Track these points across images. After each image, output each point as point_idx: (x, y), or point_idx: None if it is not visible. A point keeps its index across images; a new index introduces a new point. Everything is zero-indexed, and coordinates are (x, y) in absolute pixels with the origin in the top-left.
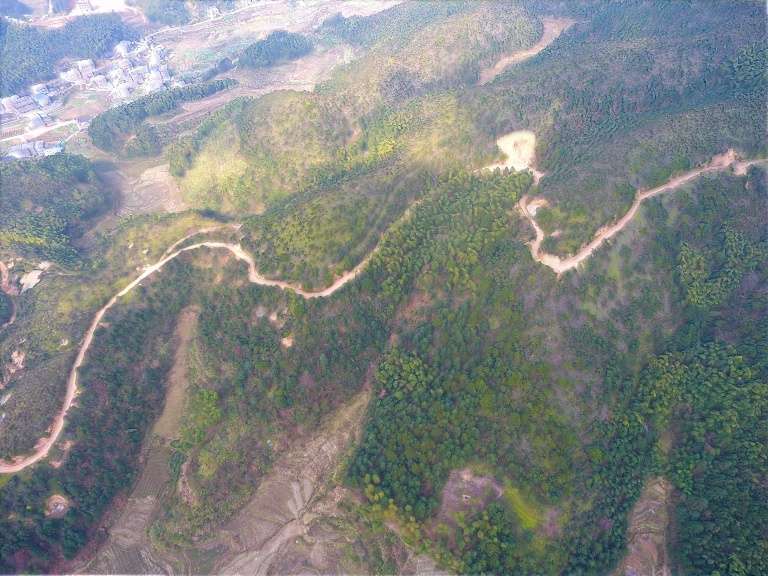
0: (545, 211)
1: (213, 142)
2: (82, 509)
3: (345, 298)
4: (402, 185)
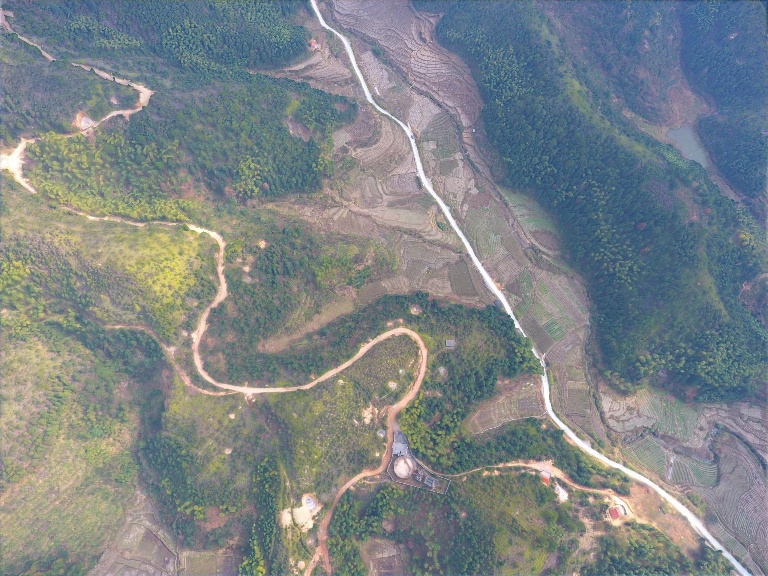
0: (95, 107)
1: (6, 554)
2: (408, 299)
3: (213, 224)
4: (78, 227)
